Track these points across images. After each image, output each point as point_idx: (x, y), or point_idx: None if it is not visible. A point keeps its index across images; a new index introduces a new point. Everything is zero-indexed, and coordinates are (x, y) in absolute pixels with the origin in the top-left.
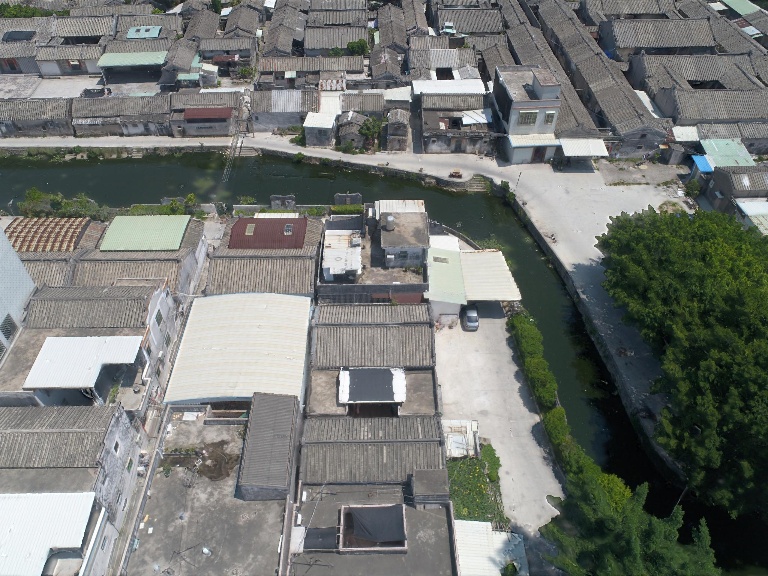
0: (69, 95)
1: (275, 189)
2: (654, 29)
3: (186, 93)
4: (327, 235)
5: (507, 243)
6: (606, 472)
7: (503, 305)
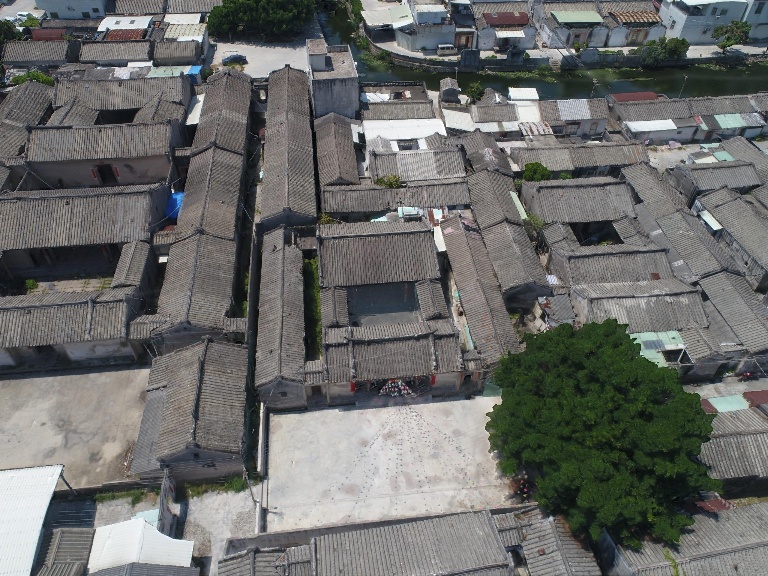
0: None
1: None
2: (89, 193)
3: None
4: (468, 1)
5: (358, 64)
6: (333, 5)
7: None
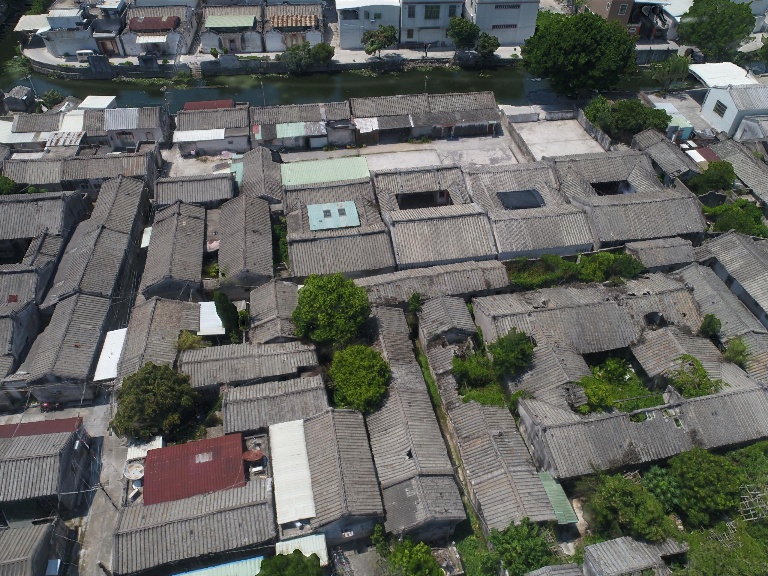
0: (396, 162)
1: (158, 95)
2: None
3: (232, 109)
4: (117, 5)
5: None
6: None
7: (32, 36)
